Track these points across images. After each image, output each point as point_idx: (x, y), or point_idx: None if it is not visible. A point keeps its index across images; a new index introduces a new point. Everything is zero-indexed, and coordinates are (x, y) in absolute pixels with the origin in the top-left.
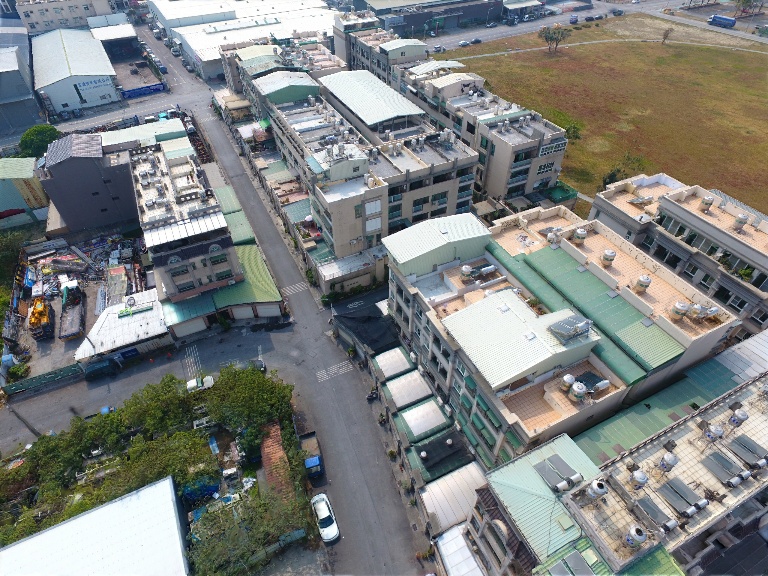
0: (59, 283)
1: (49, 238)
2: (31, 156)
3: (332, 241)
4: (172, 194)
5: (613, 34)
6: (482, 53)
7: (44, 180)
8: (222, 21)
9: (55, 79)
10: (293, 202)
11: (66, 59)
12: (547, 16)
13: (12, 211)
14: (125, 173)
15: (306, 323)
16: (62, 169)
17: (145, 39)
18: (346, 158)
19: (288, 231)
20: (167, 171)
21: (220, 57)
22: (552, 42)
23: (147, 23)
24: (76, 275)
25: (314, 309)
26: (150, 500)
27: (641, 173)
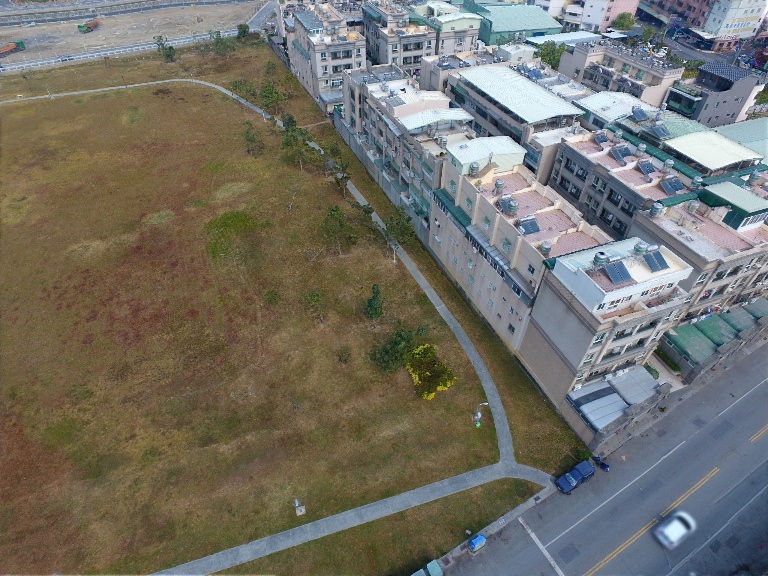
0: None
1: None
2: None
3: None
4: None
5: None
6: None
7: None
8: None
9: None
10: None
11: None
12: None
13: None
14: None
15: None
16: None
17: None
18: None
19: None
20: None
21: None
22: None
23: None
24: None
25: None
26: (542, 42)
27: (232, 157)
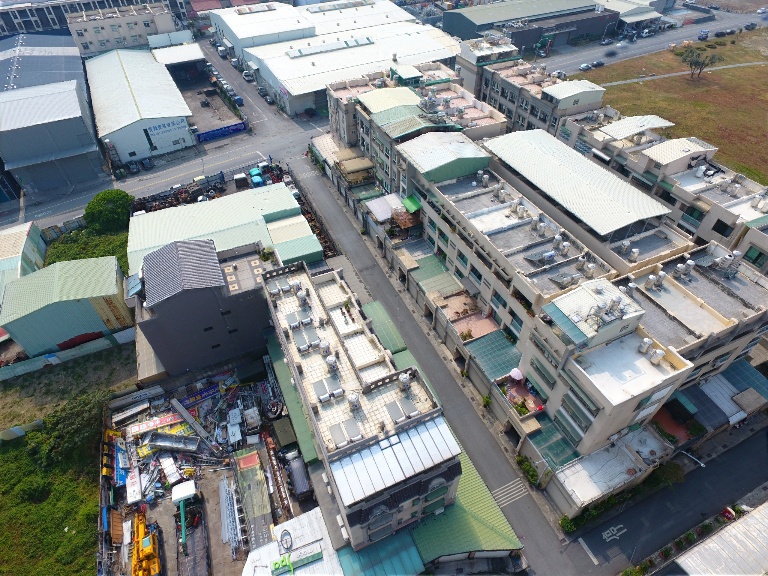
0: (162, 472)
1: (141, 387)
2: (99, 232)
3: (580, 434)
4: (348, 369)
5: (757, 54)
6: (611, 80)
7: (143, 321)
8: (301, 39)
9: (122, 123)
10: (479, 337)
11: (131, 93)
12: (666, 30)
13: (86, 335)
14: (250, 300)
15: (551, 574)
16: (169, 306)
17: (208, 58)
18: (620, 317)
19: (467, 375)
20: (326, 316)
21: (312, 90)
22: (697, 67)
23: (207, 37)
24: (185, 456)
25: (553, 541)
26: None
27: None
